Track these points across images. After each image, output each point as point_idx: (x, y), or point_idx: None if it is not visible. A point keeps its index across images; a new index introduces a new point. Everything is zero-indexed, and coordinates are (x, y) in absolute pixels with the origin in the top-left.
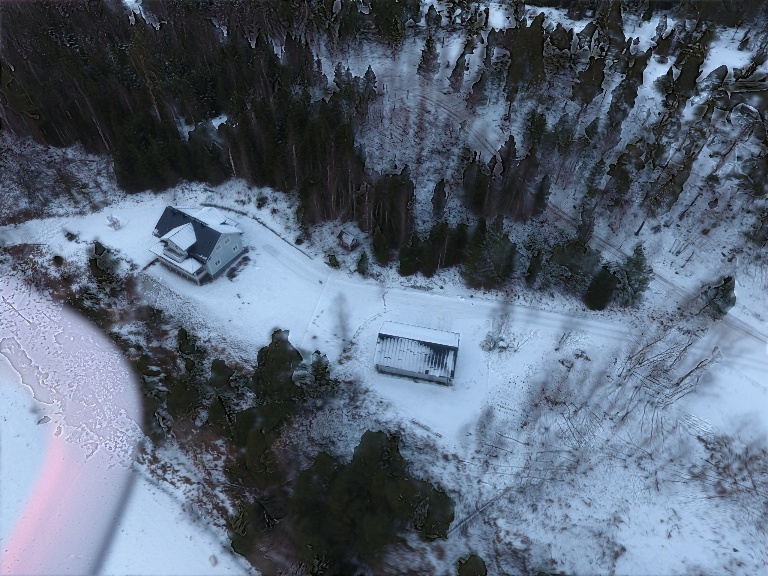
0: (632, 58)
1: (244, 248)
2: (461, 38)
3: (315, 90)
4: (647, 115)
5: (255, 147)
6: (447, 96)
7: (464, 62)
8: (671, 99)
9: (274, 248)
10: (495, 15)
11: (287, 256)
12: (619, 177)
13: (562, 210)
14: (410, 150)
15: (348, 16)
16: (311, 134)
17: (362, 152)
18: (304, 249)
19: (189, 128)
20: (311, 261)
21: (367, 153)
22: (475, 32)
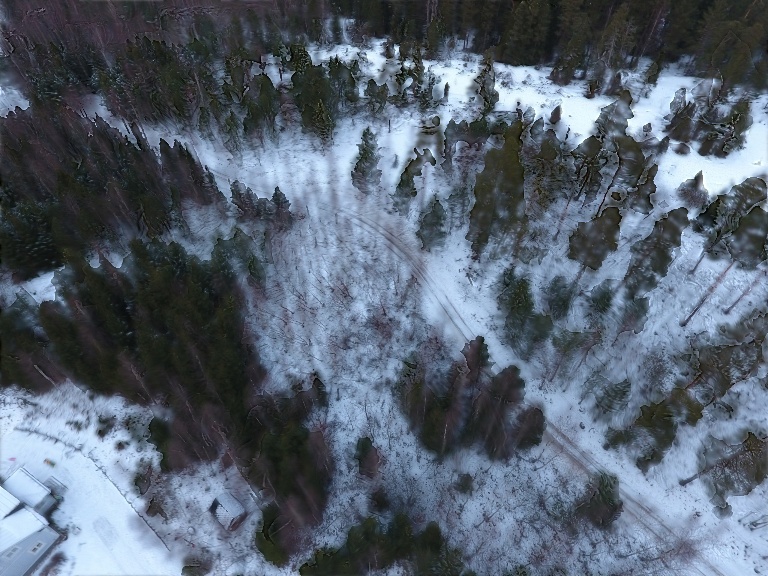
0: (641, 147)
1: (61, 531)
2: (414, 117)
3: (210, 211)
4: (676, 255)
5: (86, 349)
6: (392, 217)
7: (411, 179)
8: (706, 224)
9: (111, 525)
10: (458, 81)
11: (129, 544)
12: (658, 426)
13: (563, 432)
14: (335, 322)
15: (256, 101)
16: (173, 326)
17: (252, 352)
18: (159, 526)
19: (16, 289)
20: (167, 554)
21: (270, 331)
22: (431, 112)
